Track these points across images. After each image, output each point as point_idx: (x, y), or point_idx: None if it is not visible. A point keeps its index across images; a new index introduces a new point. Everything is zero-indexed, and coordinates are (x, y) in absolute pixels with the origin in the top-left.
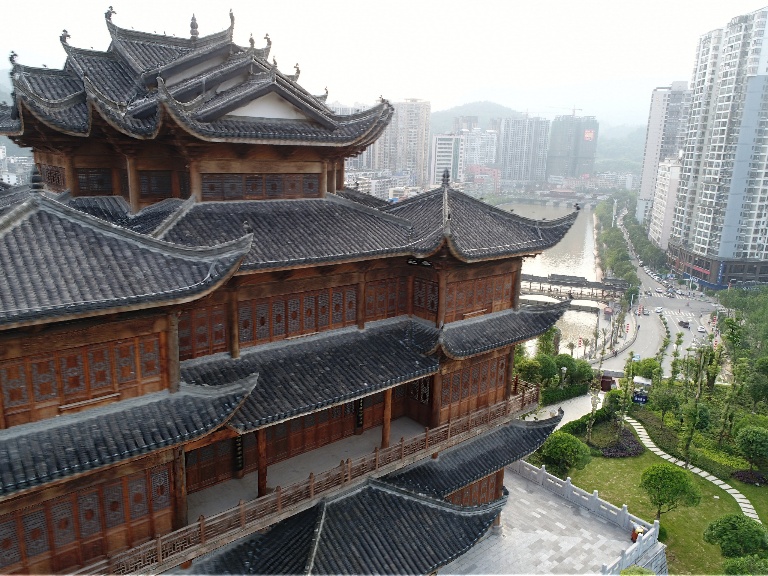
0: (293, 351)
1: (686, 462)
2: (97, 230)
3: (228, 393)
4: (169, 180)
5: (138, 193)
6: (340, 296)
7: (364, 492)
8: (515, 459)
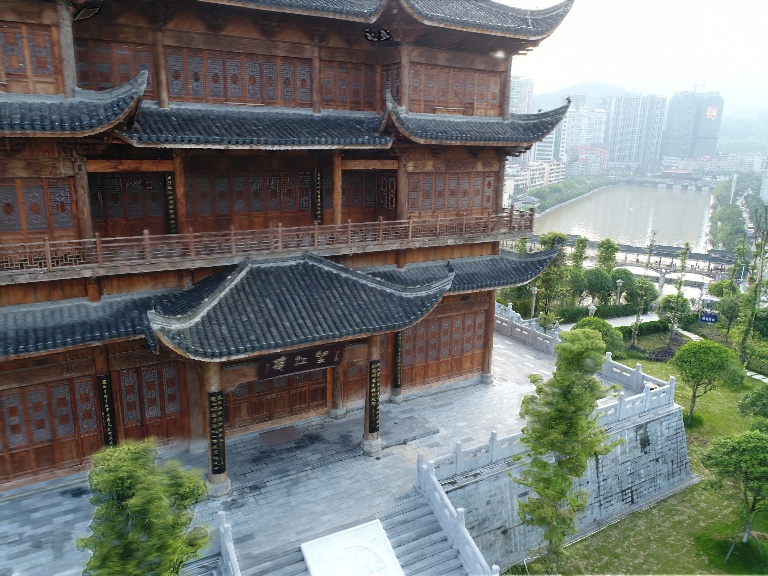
0: (230, 114)
1: (742, 359)
2: None
3: (119, 96)
4: None
5: None
6: (290, 70)
7: (298, 265)
8: (497, 284)
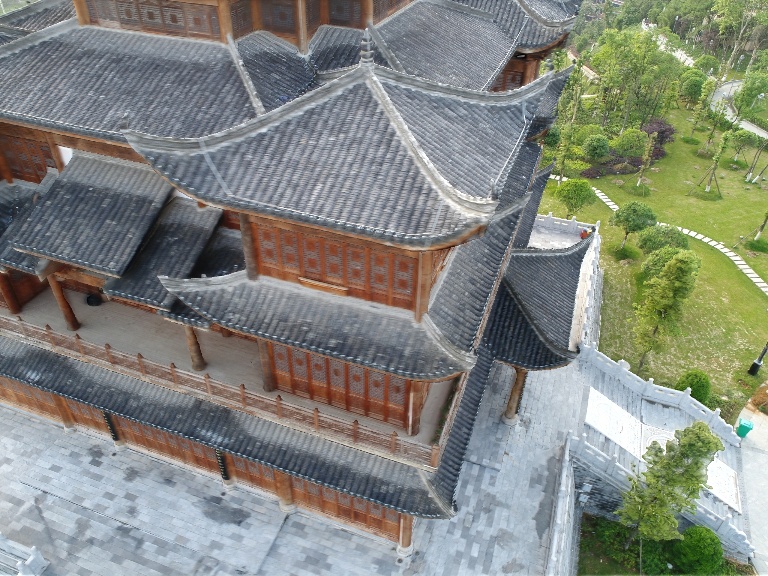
0: None
1: (562, 174)
2: (425, 92)
3: (508, 214)
4: (318, 4)
5: (306, 27)
6: None
7: (512, 260)
8: None
